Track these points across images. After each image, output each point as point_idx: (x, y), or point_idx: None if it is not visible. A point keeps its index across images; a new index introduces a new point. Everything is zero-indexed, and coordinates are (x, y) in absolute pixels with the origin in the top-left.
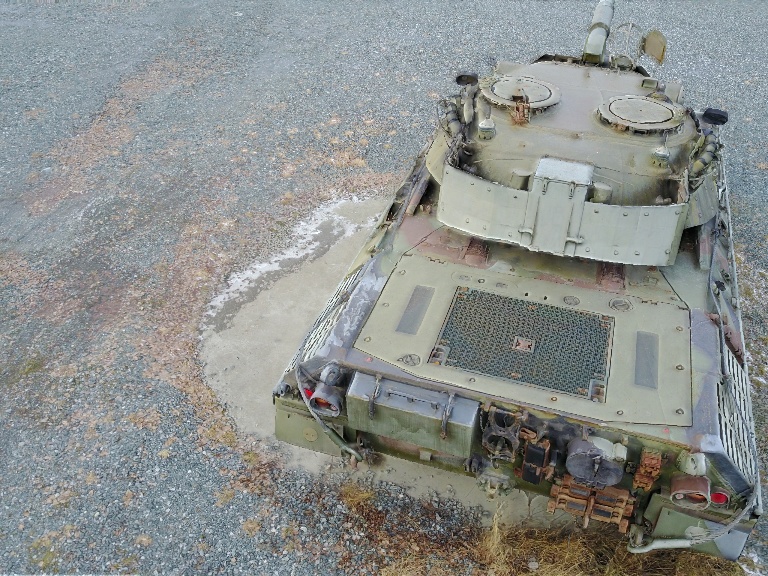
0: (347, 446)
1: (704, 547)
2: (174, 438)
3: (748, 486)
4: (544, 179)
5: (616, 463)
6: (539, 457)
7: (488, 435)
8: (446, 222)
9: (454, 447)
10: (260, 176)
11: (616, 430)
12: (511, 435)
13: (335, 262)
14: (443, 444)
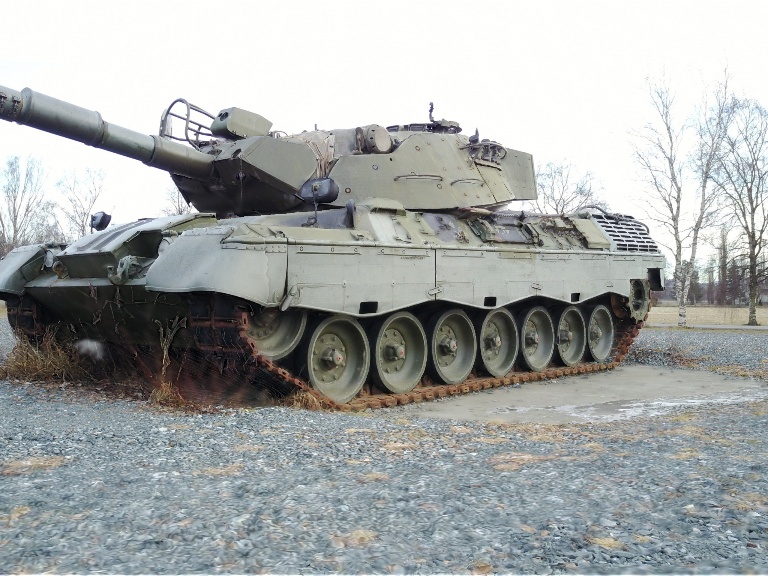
0: None
1: None
2: (762, 363)
3: None
4: None
5: None
6: None
7: None
8: None
9: None
10: (763, 430)
11: None
12: None
13: None
14: None
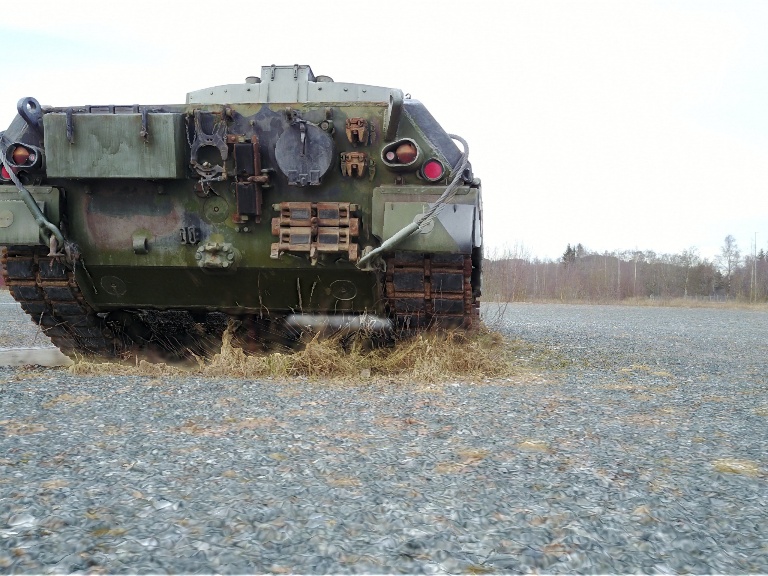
0: (46, 219)
1: (436, 239)
2: None
3: (459, 153)
4: (271, 67)
5: (322, 129)
6: (247, 152)
7: (196, 149)
8: None
9: (159, 162)
10: None
11: (319, 104)
12: (218, 139)
13: None
14: (147, 162)
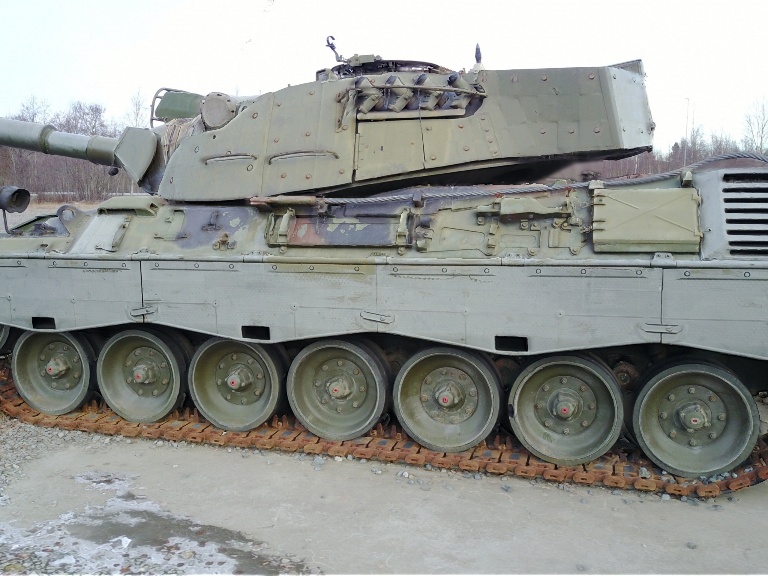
0: None
1: None
2: None
3: None
4: None
5: None
6: None
7: None
8: (631, 144)
9: None
10: None
11: None
12: None
13: (267, 517)
14: None
